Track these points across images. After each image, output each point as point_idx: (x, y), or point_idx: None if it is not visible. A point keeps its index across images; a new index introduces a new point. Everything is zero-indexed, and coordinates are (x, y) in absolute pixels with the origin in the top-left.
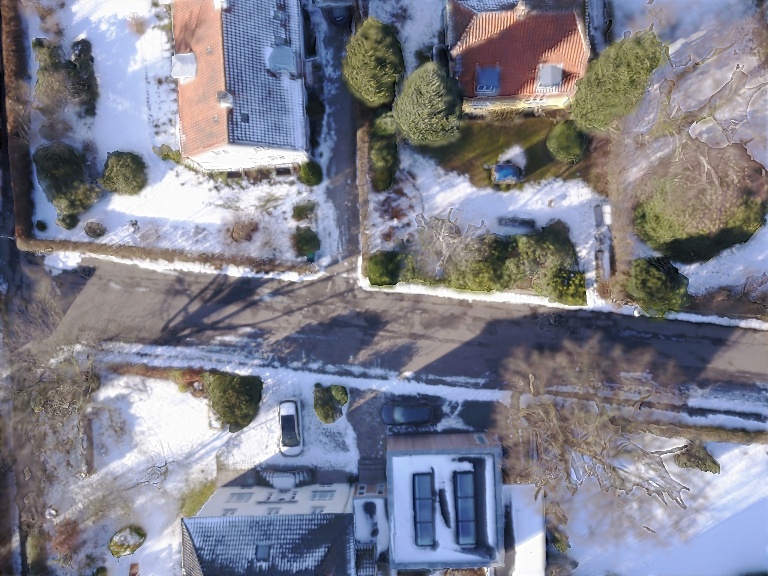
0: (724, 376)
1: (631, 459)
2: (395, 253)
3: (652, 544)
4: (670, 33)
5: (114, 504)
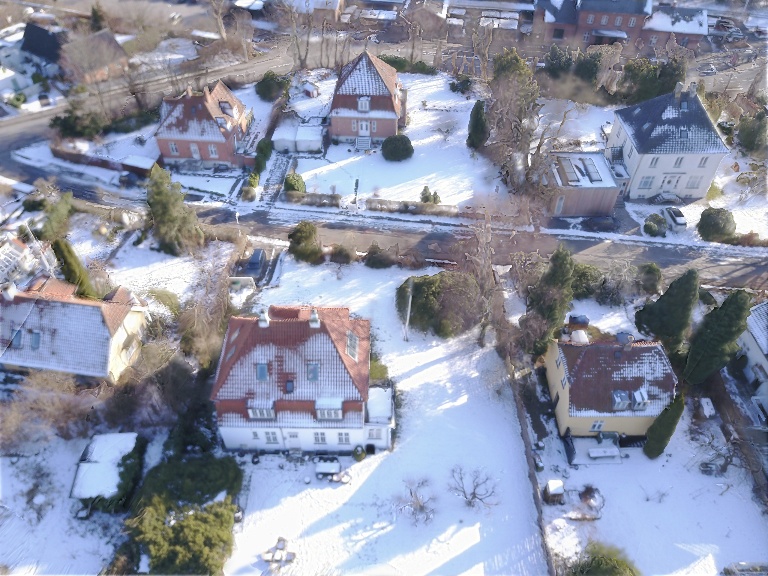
0: (411, 236)
1: (534, 121)
2: (645, 280)
3: (451, 173)
4: (466, 410)
5: (764, 193)
